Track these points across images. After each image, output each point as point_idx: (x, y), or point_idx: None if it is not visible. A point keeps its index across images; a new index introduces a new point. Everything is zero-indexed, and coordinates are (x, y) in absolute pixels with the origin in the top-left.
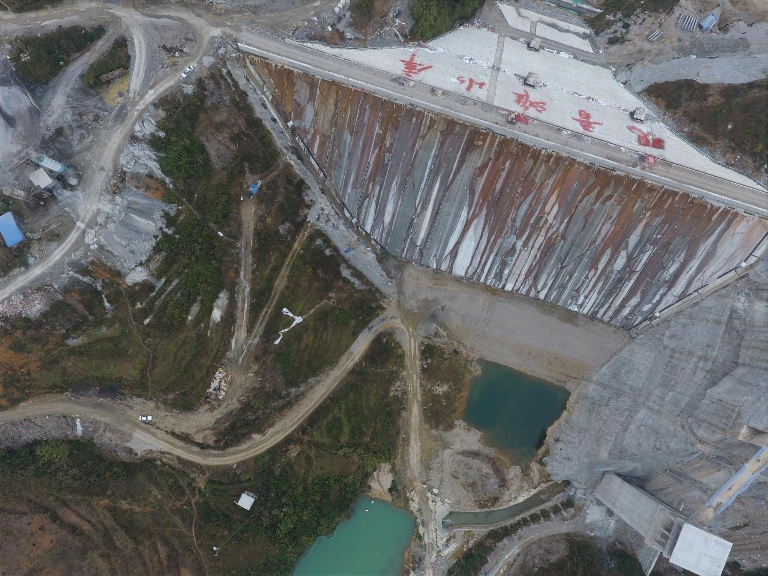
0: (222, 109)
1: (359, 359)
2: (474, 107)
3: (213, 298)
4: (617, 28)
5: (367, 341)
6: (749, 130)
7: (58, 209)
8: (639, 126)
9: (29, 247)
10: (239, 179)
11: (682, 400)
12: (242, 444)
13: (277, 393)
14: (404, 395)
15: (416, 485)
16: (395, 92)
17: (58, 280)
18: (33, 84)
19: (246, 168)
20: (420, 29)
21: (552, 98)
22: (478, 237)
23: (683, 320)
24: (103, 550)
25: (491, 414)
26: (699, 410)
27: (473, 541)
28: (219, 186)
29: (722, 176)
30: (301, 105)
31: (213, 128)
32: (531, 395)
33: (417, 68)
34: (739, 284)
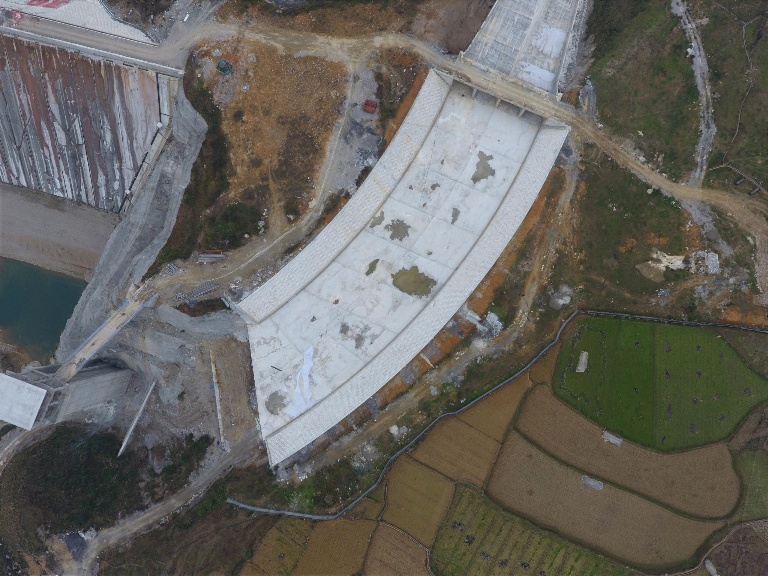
0: None
1: None
2: None
3: None
4: None
5: None
6: None
7: None
8: None
9: None
10: None
11: (114, 270)
12: None
13: None
14: None
15: None
16: None
17: None
18: None
19: None
20: None
21: None
22: None
23: None
24: None
25: (12, 311)
26: (122, 277)
27: None
28: None
29: (101, 29)
30: None
31: None
32: (55, 291)
33: None
34: (169, 148)
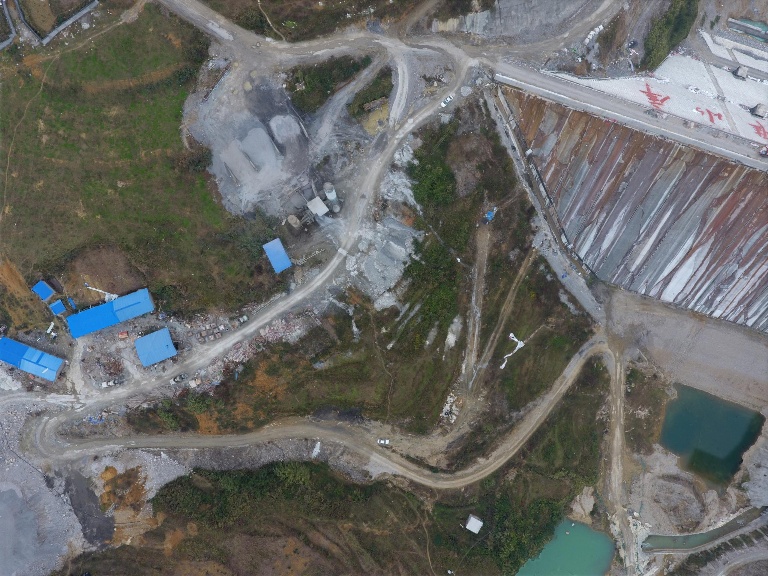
0: (472, 138)
1: (572, 383)
2: (726, 140)
3: (449, 323)
4: None
5: (578, 365)
6: None
7: (320, 236)
8: None
9: (293, 273)
10: (479, 206)
11: None
12: (468, 468)
13: (503, 417)
14: (608, 419)
15: (617, 508)
16: (649, 124)
17: (318, 306)
18: (304, 113)
19: (485, 195)
20: (652, 59)
21: None
22: (698, 265)
23: None
24: (353, 573)
25: (686, 438)
26: None
27: (674, 565)
28: (462, 213)
29: None
30: (545, 134)
31: (464, 156)
32: (725, 420)
33: (658, 99)
34: None
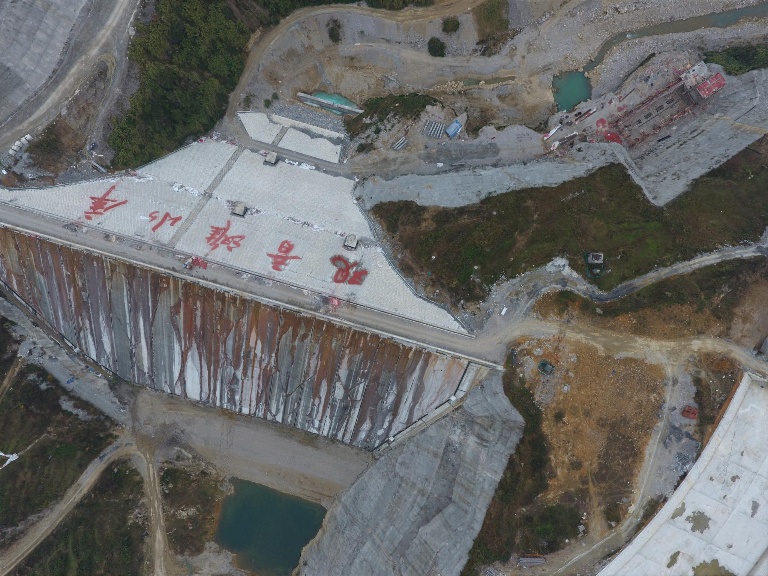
0: None
1: (88, 491)
2: (150, 252)
3: None
4: (370, 133)
5: (97, 471)
6: (448, 263)
7: None
8: (348, 255)
9: None
10: None
11: (397, 537)
12: None
13: None
14: (146, 521)
15: None
16: (67, 239)
17: None
18: None
19: None
20: (120, 160)
21: (257, 228)
22: (198, 367)
23: (412, 447)
24: None
25: (246, 534)
26: (410, 550)
27: None
28: None
29: (414, 315)
30: None
31: None
32: (288, 512)
33: (105, 206)
34: (455, 415)
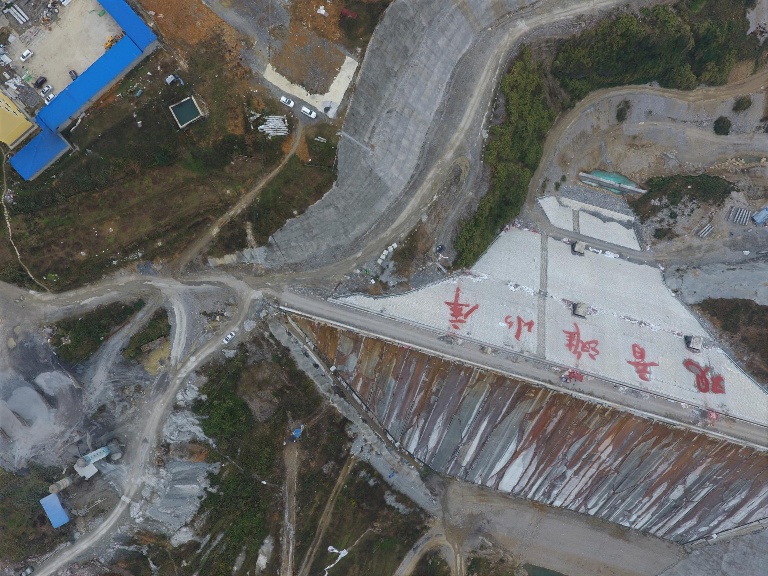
0: (264, 366)
1: None
2: (526, 364)
3: (258, 546)
4: (663, 216)
5: (412, 563)
6: None
7: (102, 484)
8: (696, 358)
9: (75, 524)
10: (282, 427)
11: None
12: None
13: None
14: None
15: None
16: (443, 351)
17: (104, 554)
18: (74, 364)
19: (289, 415)
20: (464, 261)
21: (603, 331)
22: (526, 464)
23: (743, 547)
24: None
25: None
26: None
27: None
28: (262, 438)
29: None
30: (344, 354)
31: (256, 387)
32: None
33: (463, 312)
34: None
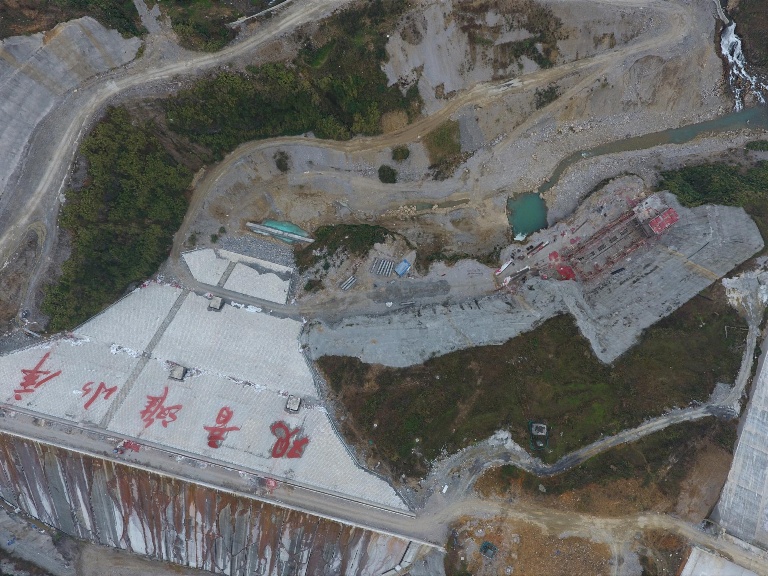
0: None
1: None
2: (80, 436)
3: None
4: (319, 267)
5: None
6: (389, 434)
7: None
8: (289, 419)
9: None
10: None
11: None
12: None
13: None
14: None
15: None
16: None
17: None
18: None
19: None
20: (55, 326)
21: (196, 394)
22: (141, 529)
23: None
24: None
25: None
26: None
27: None
28: None
29: (354, 492)
30: None
31: None
32: None
33: (37, 381)
34: None
